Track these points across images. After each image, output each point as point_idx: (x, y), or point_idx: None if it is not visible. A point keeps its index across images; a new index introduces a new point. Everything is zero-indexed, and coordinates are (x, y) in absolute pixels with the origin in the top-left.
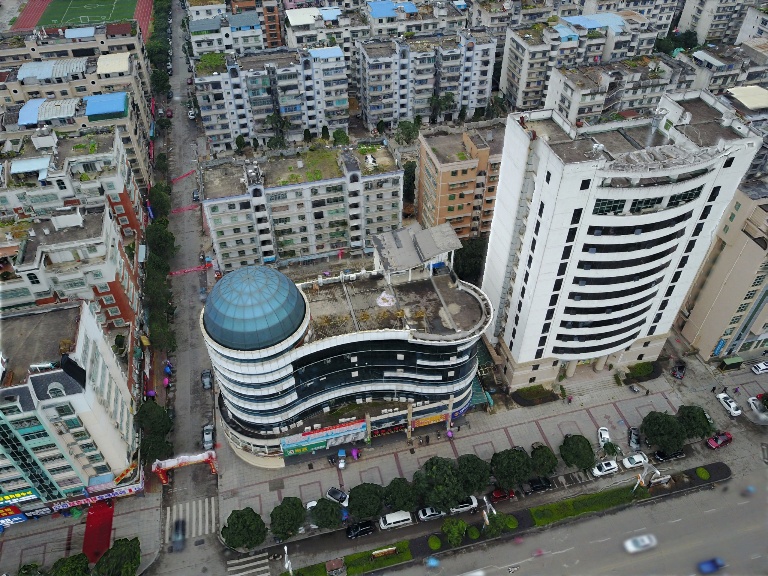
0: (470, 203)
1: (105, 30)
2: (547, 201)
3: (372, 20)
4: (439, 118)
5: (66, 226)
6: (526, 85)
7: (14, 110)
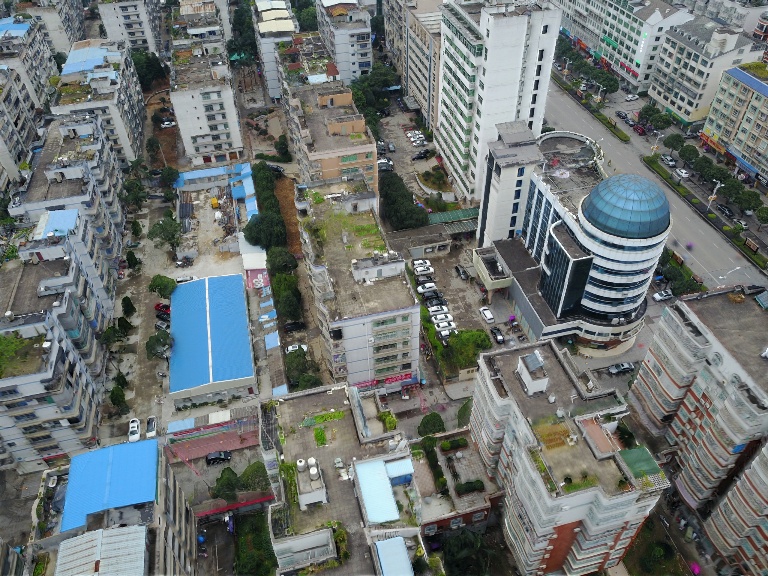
0: None
1: None
2: (548, 44)
3: None
4: None
5: None
6: (128, 139)
7: None
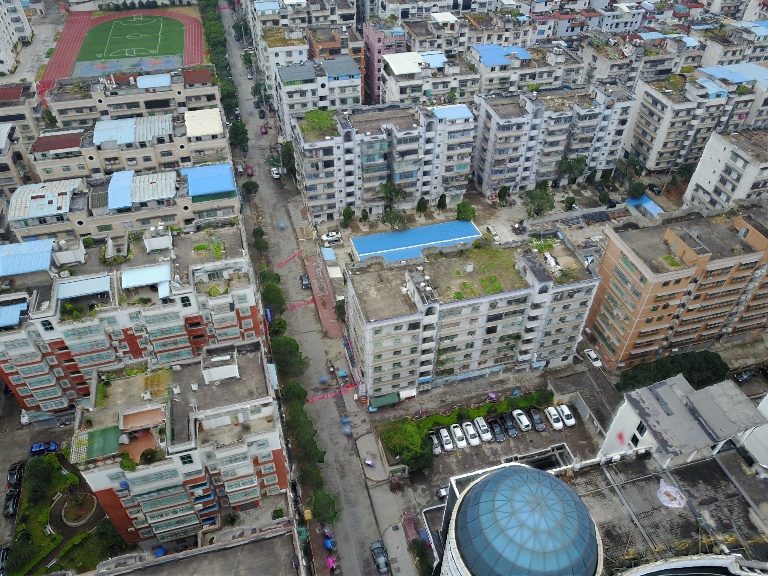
0: (671, 313)
1: (182, 78)
2: None
3: (482, 68)
4: (563, 181)
5: (219, 378)
6: (663, 145)
7: (100, 188)
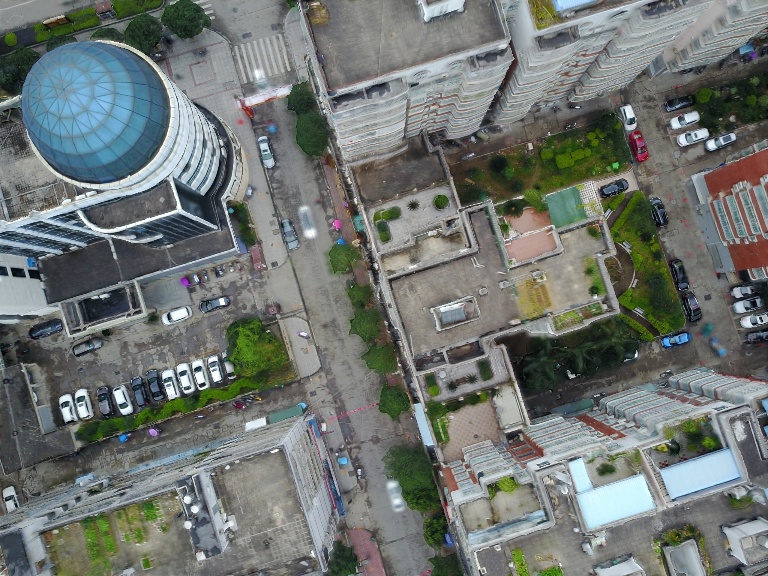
0: None
1: None
2: None
3: None
4: None
5: None
6: None
7: None
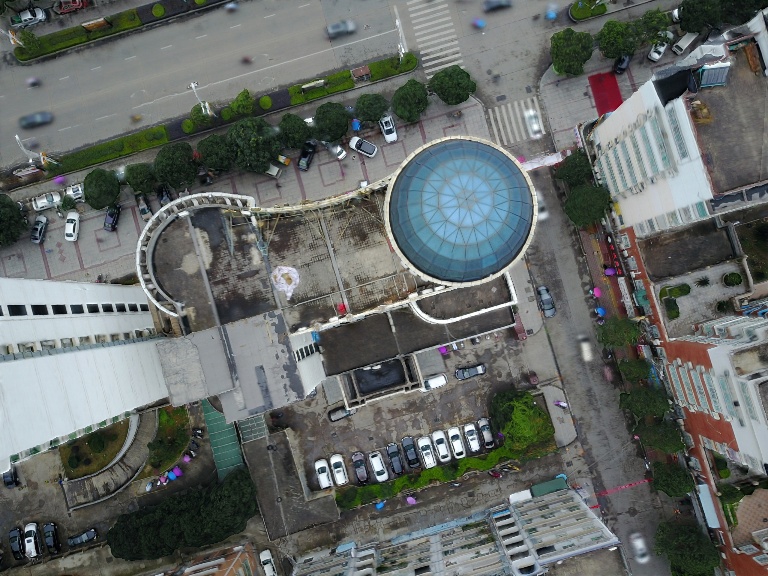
0: None
1: None
2: None
3: None
4: None
5: None
6: None
7: None
